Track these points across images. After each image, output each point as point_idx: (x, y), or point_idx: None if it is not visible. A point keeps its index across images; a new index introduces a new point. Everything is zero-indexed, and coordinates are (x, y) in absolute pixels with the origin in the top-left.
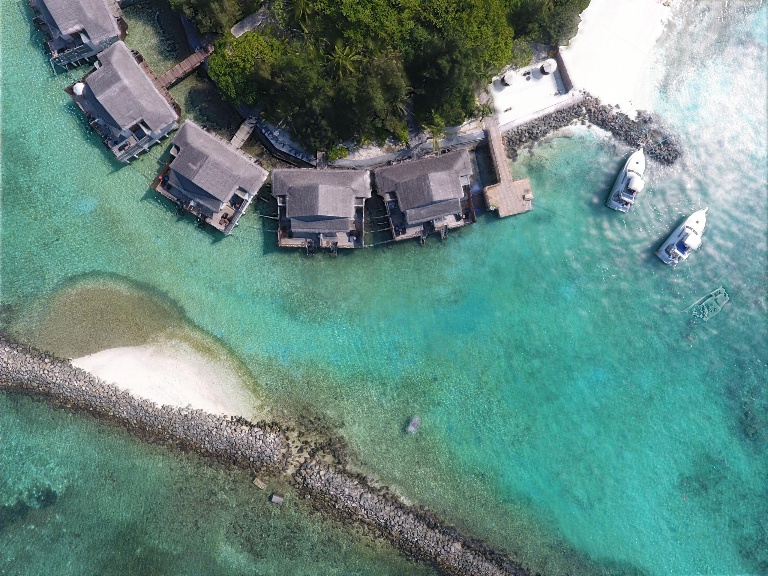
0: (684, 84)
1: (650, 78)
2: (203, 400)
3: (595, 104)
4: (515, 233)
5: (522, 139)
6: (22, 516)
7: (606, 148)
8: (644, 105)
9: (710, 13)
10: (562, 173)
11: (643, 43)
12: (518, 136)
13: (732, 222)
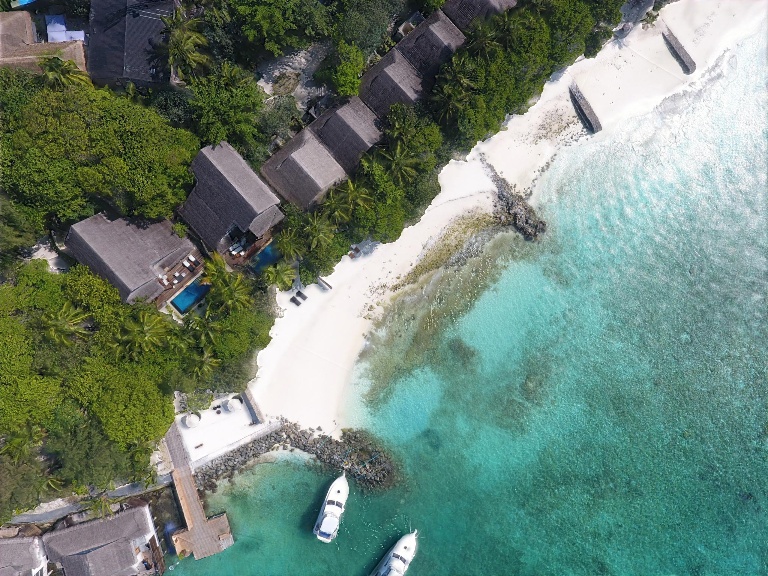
0: (392, 396)
1: (355, 394)
2: None
3: (295, 429)
4: (221, 565)
5: (217, 473)
6: None
7: (313, 469)
8: (350, 422)
9: (415, 321)
10: (268, 498)
11: (344, 360)
12: (214, 470)
13: (452, 532)
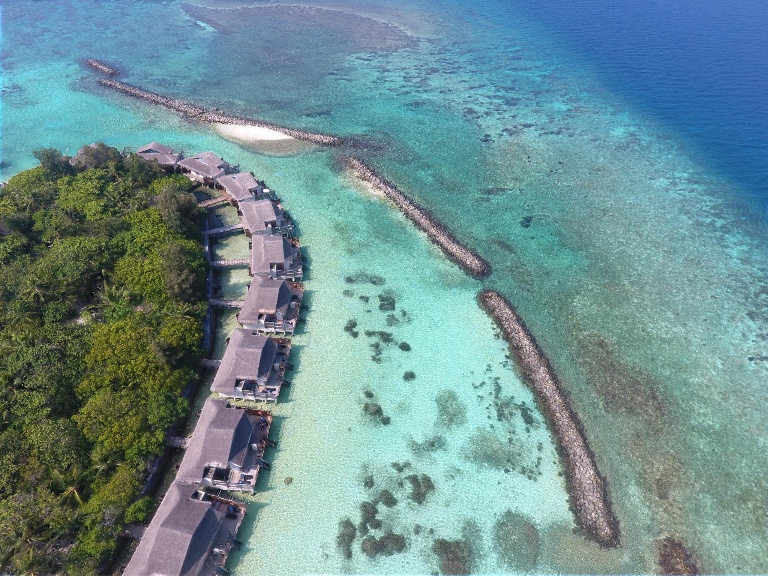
0: None
1: None
2: (238, 127)
3: None
4: None
5: None
6: (319, 113)
7: None
8: None
9: None
10: None
11: None
12: None
13: None
